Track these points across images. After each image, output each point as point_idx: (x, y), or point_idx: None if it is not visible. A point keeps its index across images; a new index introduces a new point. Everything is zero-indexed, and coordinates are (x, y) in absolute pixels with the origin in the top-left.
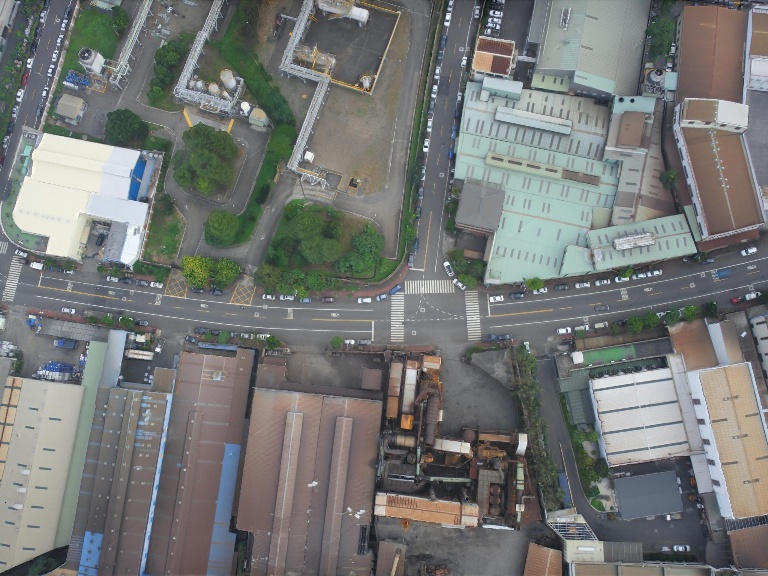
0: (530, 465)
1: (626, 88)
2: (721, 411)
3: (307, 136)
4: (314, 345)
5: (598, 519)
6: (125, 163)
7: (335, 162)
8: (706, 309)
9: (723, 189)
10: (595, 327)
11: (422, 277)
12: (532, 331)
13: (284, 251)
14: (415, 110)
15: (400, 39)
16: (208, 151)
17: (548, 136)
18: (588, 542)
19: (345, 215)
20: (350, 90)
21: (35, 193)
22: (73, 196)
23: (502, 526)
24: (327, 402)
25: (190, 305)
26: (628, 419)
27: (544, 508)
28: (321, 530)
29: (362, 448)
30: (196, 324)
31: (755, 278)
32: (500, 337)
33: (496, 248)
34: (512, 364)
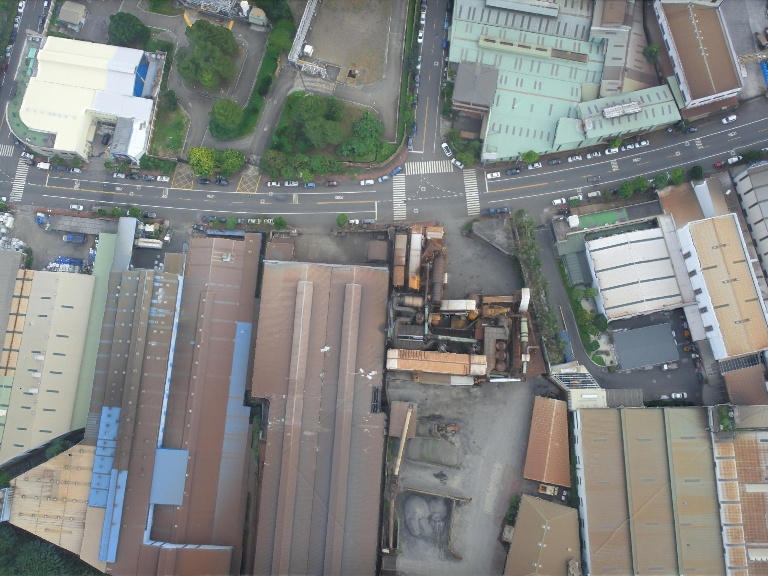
0: (533, 320)
1: None
2: (711, 259)
3: (306, 30)
4: (320, 227)
5: (599, 373)
6: (129, 61)
7: (333, 55)
8: (692, 171)
9: (703, 57)
10: (588, 196)
11: (421, 159)
12: (529, 204)
13: (287, 139)
14: (408, 5)
15: None
16: (211, 44)
17: (536, 20)
18: (591, 390)
19: (345, 104)
20: None
21: (41, 92)
22: (79, 94)
23: (509, 378)
24: (336, 272)
25: (197, 196)
26: (624, 275)
27: (548, 362)
28: (335, 390)
29: (371, 313)
30: (203, 213)
31: (736, 144)
32: (498, 210)
33: (492, 125)
34: (512, 230)
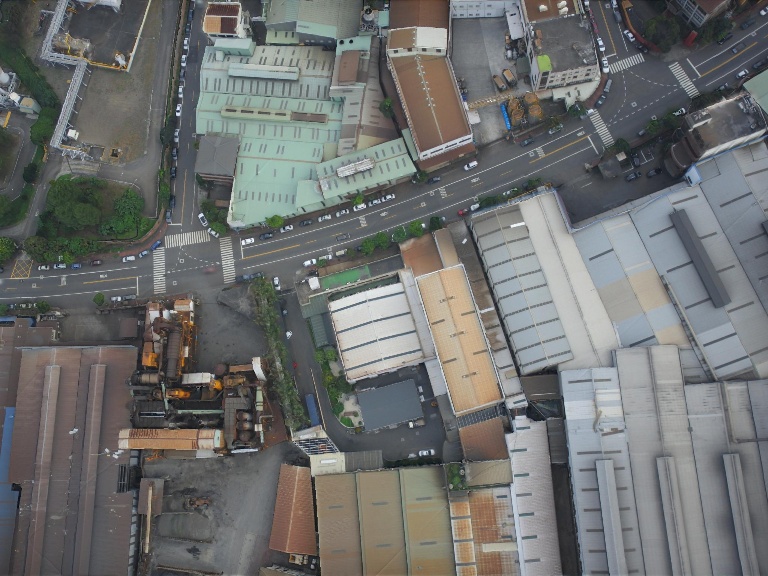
0: (270, 388)
1: (349, 32)
2: (438, 313)
3: (68, 115)
4: (85, 306)
5: (348, 435)
6: None
7: (98, 136)
8: (430, 223)
9: (430, 108)
10: (336, 255)
11: (180, 231)
12: (281, 267)
13: (53, 223)
14: (169, 80)
15: (153, 18)
16: None
17: (279, 84)
18: (330, 455)
19: (108, 183)
20: (109, 70)
21: None
22: None
23: (248, 449)
24: (85, 353)
25: None
26: (363, 334)
27: (290, 428)
28: (80, 473)
29: (118, 392)
30: None
31: (479, 190)
32: (252, 276)
33: (238, 193)
34: (254, 297)
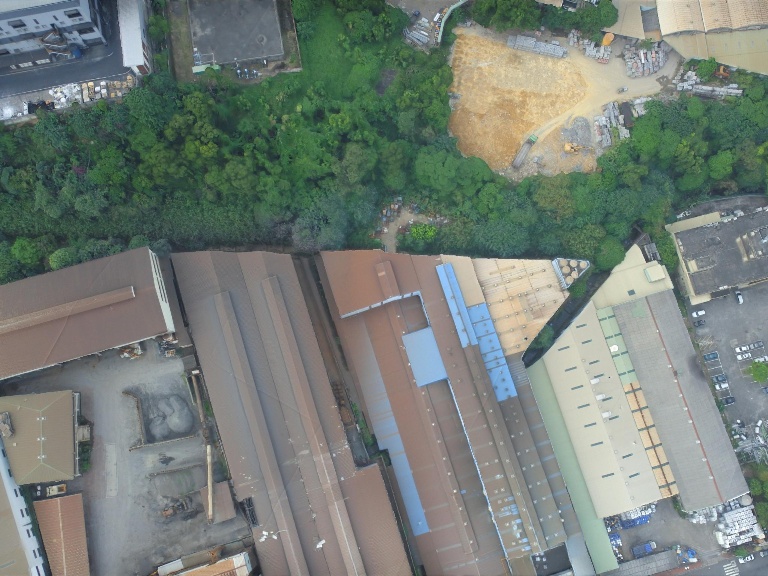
0: None
1: None
2: None
3: None
4: None
5: None
6: None
7: None
8: None
9: None
10: None
11: None
12: None
13: None
14: None
15: None
16: None
17: None
18: None
19: None
20: None
21: None
22: None
23: None
24: None
25: None
26: None
27: None
28: (294, 506)
29: None
30: None
31: None
32: None
33: None
34: None
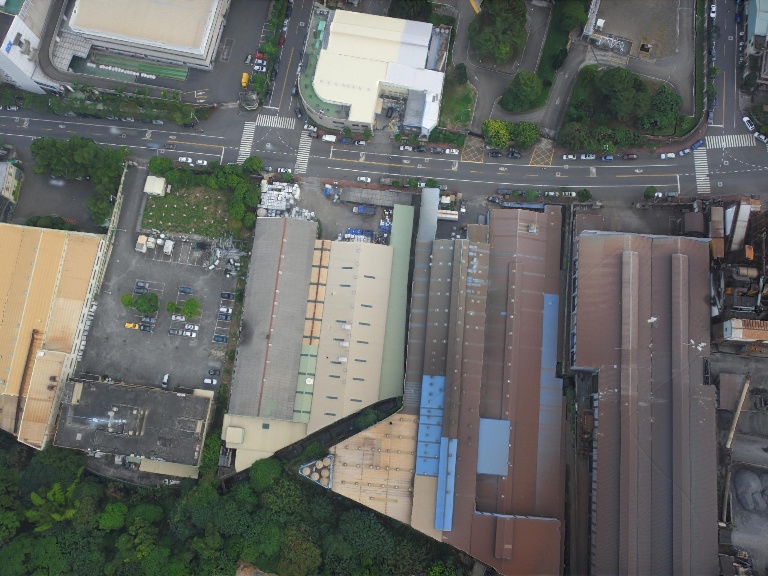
0: None
1: None
2: None
3: (599, 4)
4: (620, 200)
5: None
6: (420, 34)
7: (624, 29)
8: None
9: None
10: None
11: (722, 132)
12: None
13: (585, 112)
14: None
15: None
16: None
17: None
18: None
19: (640, 78)
20: None
21: (333, 64)
22: (371, 66)
23: None
24: (657, 243)
25: (488, 169)
26: None
27: None
28: (667, 361)
29: (696, 285)
30: (497, 186)
31: None
32: None
33: None
34: None
